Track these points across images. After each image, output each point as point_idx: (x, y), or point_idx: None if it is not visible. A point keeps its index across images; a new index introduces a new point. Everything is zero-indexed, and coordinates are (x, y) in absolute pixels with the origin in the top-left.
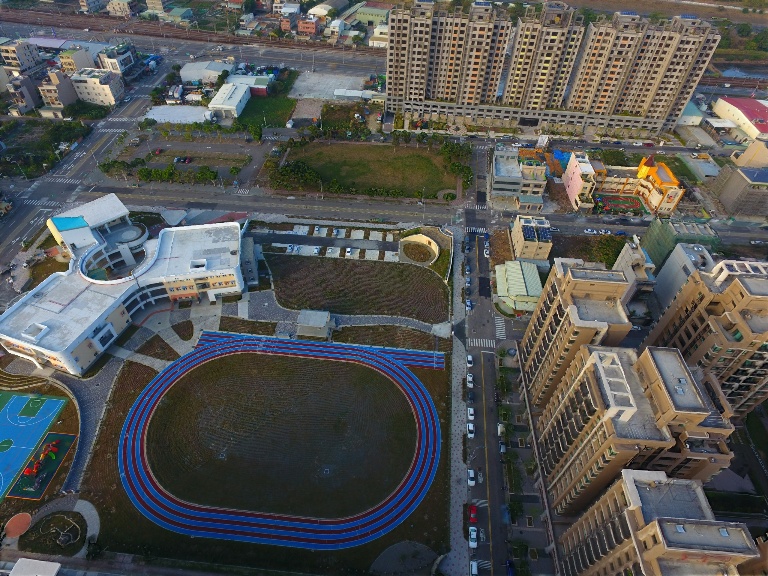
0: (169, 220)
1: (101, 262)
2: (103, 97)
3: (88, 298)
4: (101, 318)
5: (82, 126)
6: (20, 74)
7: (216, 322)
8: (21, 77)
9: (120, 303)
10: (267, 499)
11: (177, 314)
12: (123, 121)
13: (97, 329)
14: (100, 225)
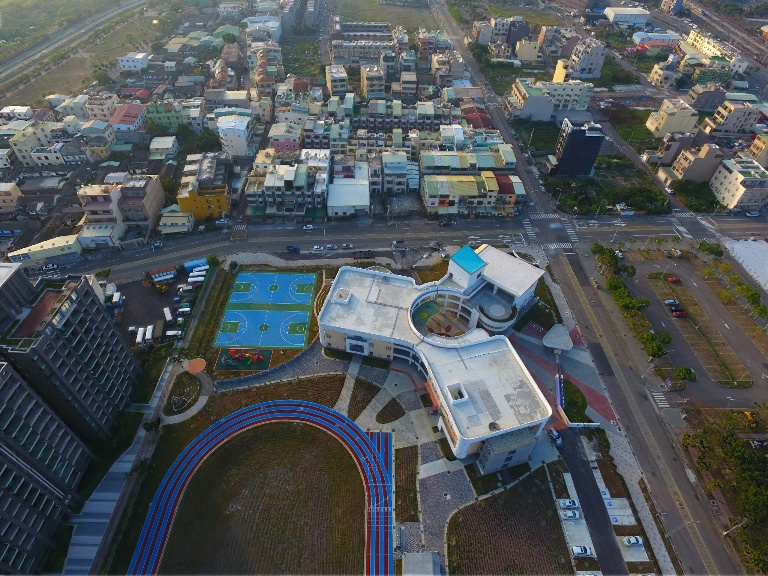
0: (549, 336)
1: (454, 304)
2: (729, 195)
3: (388, 314)
4: (364, 334)
5: (664, 204)
6: (710, 131)
7: (407, 442)
8: (688, 134)
9: (388, 341)
10: (171, 575)
11: (411, 397)
12: (706, 228)
13: (360, 336)
14: (491, 282)
